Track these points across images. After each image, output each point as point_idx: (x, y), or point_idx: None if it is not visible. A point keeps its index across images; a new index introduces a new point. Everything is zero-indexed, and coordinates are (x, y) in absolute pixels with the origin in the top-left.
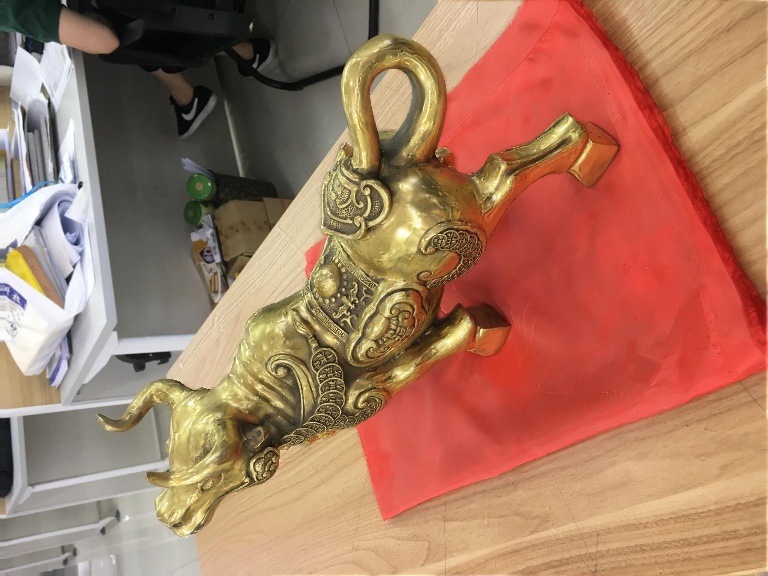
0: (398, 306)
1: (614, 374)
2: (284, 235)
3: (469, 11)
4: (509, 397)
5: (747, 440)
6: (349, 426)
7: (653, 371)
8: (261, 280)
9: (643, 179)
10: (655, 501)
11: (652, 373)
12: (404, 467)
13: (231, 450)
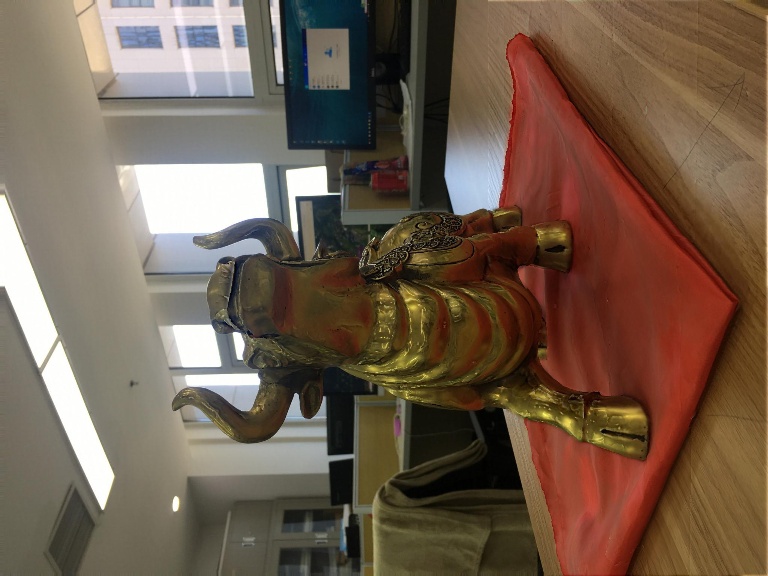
0: None
1: None
2: None
3: None
4: (577, 182)
5: (547, 9)
6: (434, 247)
7: None
8: None
9: (516, 179)
10: (574, 6)
11: None
12: (653, 292)
13: None
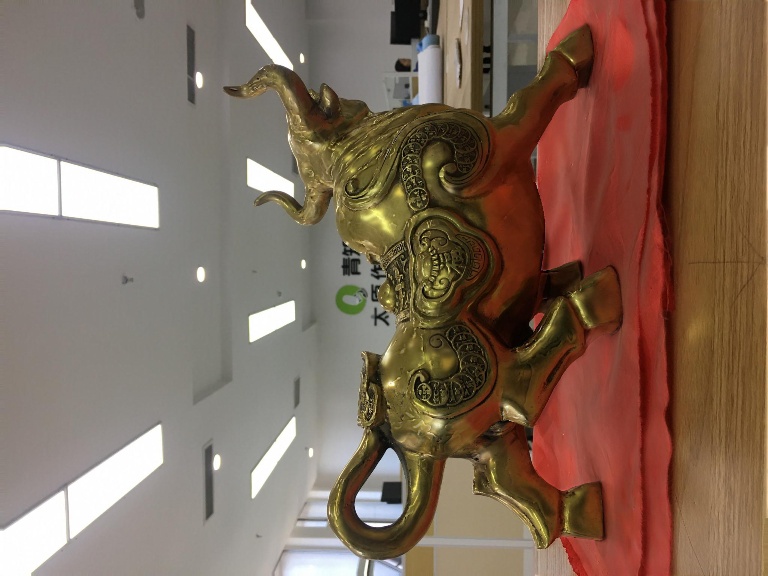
0: None
1: (551, 397)
2: None
3: (715, 572)
4: None
5: None
6: None
7: (541, 429)
8: None
9: None
10: None
11: (541, 428)
12: None
13: None
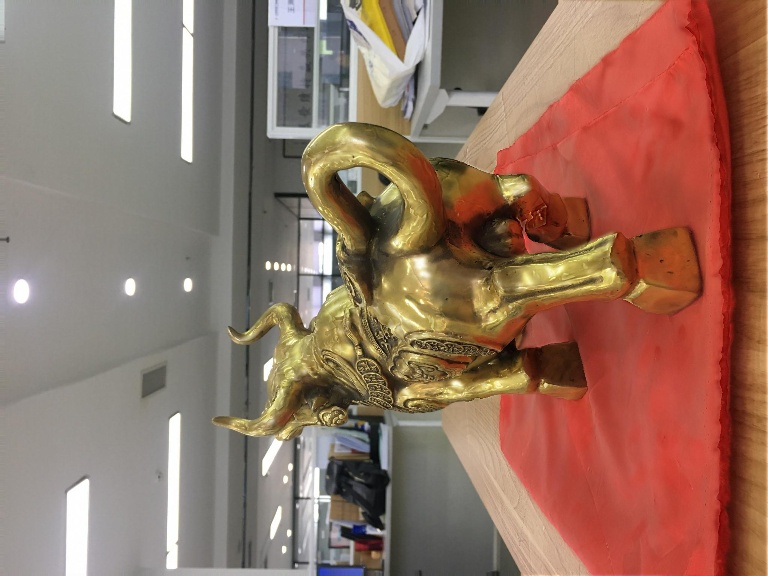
0: (415, 362)
1: (621, 535)
2: (503, 107)
3: None
4: (571, 452)
5: None
6: None
7: None
8: (488, 141)
9: (704, 360)
10: None
11: None
12: (514, 424)
13: (275, 422)
